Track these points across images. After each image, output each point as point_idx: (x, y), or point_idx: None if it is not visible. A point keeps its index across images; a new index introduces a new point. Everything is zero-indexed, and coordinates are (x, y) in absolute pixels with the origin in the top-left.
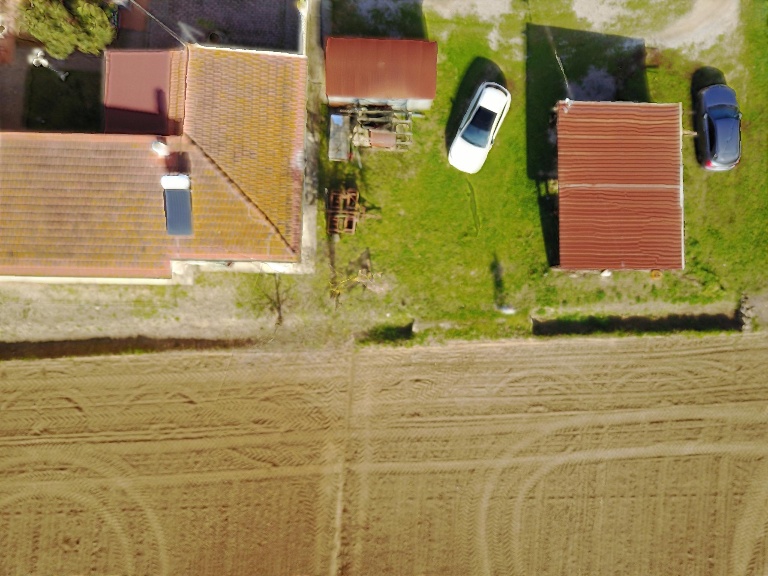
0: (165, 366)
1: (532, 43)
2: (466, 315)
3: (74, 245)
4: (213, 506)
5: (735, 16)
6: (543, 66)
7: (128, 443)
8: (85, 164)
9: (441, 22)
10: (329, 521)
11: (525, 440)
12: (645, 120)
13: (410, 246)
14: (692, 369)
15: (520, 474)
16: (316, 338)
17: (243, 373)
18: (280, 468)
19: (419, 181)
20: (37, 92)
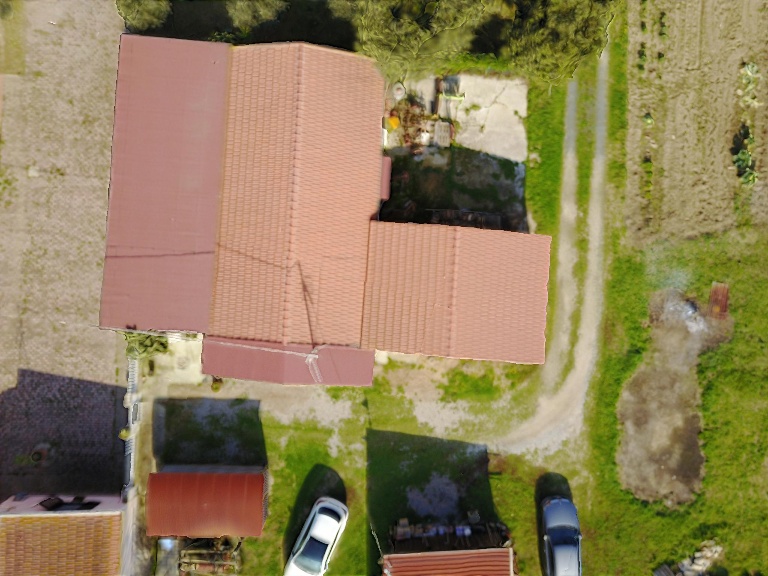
0: None
1: (372, 448)
2: None
3: None
4: None
5: (578, 421)
6: (384, 472)
7: None
8: None
9: (278, 428)
10: None
11: None
12: (475, 566)
13: None
14: None
15: None
16: None
17: None
18: None
19: None
20: None
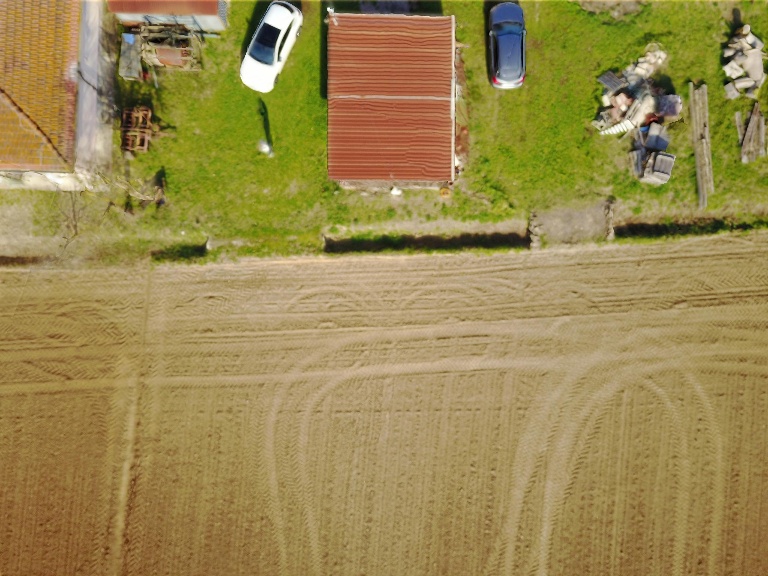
0: None
1: None
2: (258, 233)
3: None
4: (8, 417)
5: None
6: None
7: None
8: None
9: None
10: (122, 433)
11: (315, 355)
12: (418, 33)
13: (205, 165)
14: (481, 287)
15: (309, 388)
16: (113, 255)
17: (41, 289)
18: (74, 381)
19: (214, 101)
20: None
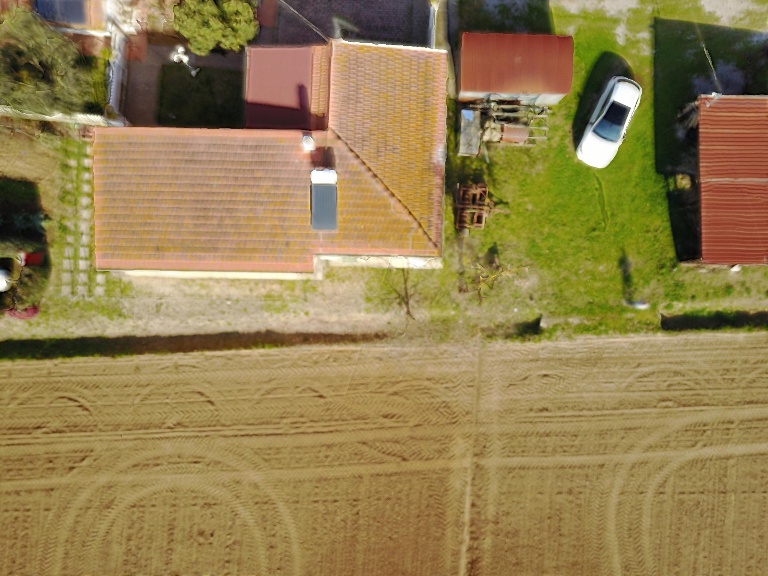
0: (295, 360)
1: (660, 37)
2: (595, 310)
3: (219, 240)
4: (344, 500)
5: None
6: (671, 60)
7: (260, 437)
8: (231, 159)
9: (568, 17)
10: (459, 515)
11: (655, 435)
12: None
13: (538, 241)
14: None
15: (650, 469)
16: (443, 333)
17: (371, 367)
18: (410, 462)
19: (546, 176)
20: (168, 88)
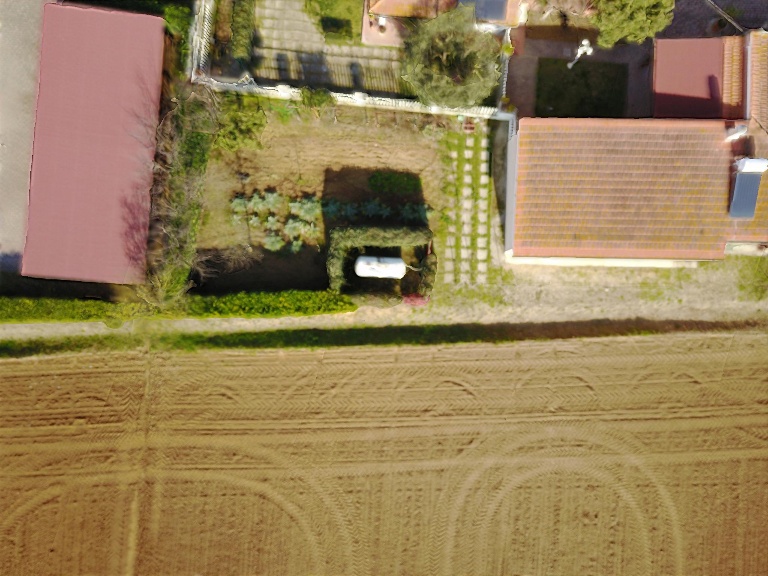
0: (669, 347)
1: None
2: None
3: (635, 227)
4: (723, 483)
5: None
6: None
7: (639, 421)
8: (651, 148)
9: None
10: None
11: None
12: None
13: None
14: None
15: None
16: None
17: (744, 354)
18: None
19: None
20: (544, 80)
